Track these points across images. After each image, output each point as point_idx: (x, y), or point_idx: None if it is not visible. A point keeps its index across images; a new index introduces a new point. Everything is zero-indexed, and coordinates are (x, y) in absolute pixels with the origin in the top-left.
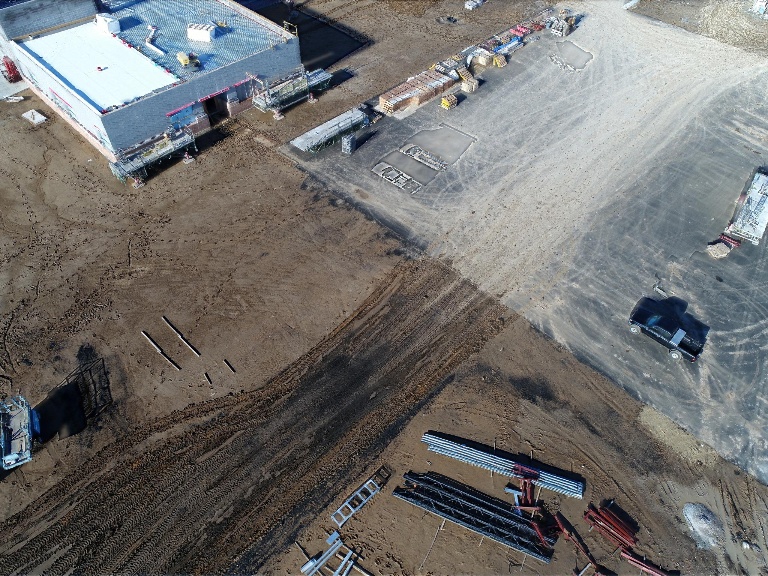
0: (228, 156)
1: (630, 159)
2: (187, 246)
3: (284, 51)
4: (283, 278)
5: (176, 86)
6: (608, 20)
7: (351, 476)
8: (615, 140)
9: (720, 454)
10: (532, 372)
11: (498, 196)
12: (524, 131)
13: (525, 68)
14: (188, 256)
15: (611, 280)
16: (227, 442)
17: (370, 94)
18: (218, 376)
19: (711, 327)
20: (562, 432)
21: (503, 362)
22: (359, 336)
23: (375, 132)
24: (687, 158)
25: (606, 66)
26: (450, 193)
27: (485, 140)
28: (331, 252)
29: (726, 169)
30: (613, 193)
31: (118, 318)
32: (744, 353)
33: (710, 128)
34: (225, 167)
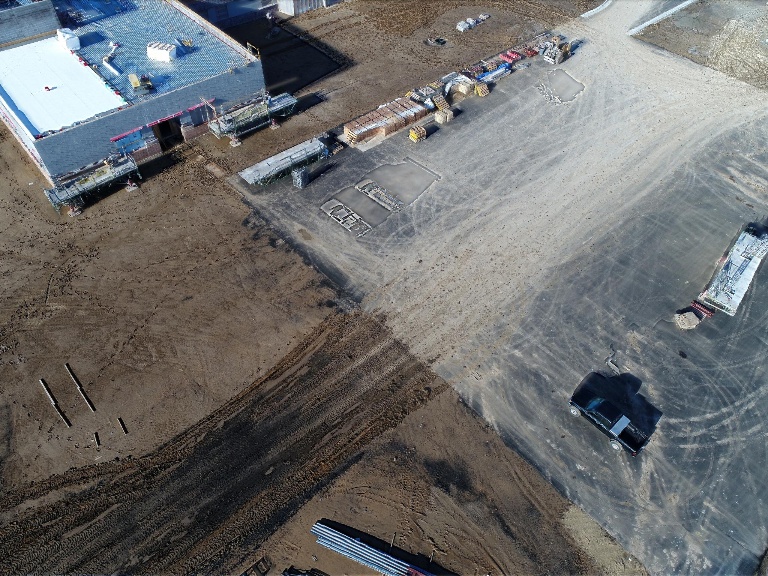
0: (174, 185)
1: (605, 207)
2: (109, 284)
3: (245, 74)
4: (202, 326)
5: (120, 111)
6: (608, 47)
7: (225, 568)
8: (592, 184)
9: (649, 572)
10: (451, 455)
11: (451, 244)
12: (494, 170)
13: (508, 98)
14: (108, 296)
15: (559, 349)
16: (100, 516)
17: (336, 122)
18: (108, 437)
19: (664, 413)
20: (472, 531)
21: (421, 441)
22: (269, 399)
23: (333, 164)
24: (669, 209)
25: (597, 99)
26: (399, 238)
27: (449, 178)
28: (259, 299)
29: (711, 224)
30: (579, 246)
31: (19, 362)
32: (697, 447)
33: (701, 175)
34: (168, 197)
